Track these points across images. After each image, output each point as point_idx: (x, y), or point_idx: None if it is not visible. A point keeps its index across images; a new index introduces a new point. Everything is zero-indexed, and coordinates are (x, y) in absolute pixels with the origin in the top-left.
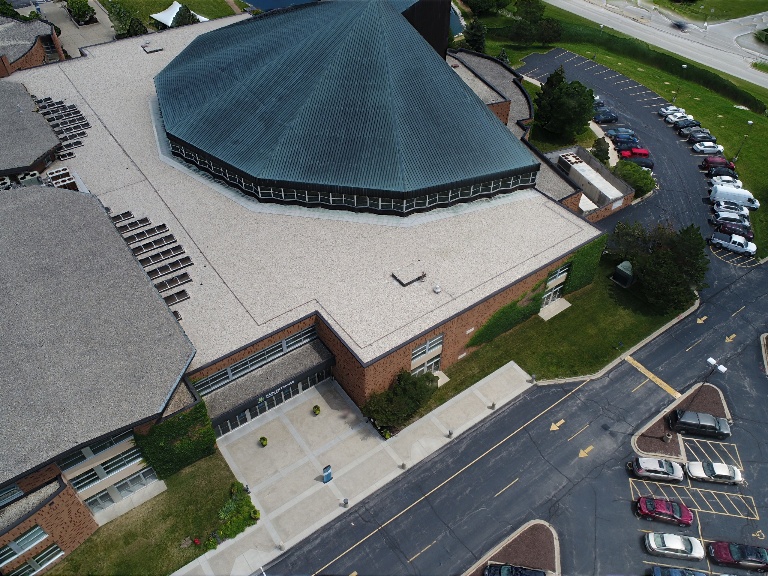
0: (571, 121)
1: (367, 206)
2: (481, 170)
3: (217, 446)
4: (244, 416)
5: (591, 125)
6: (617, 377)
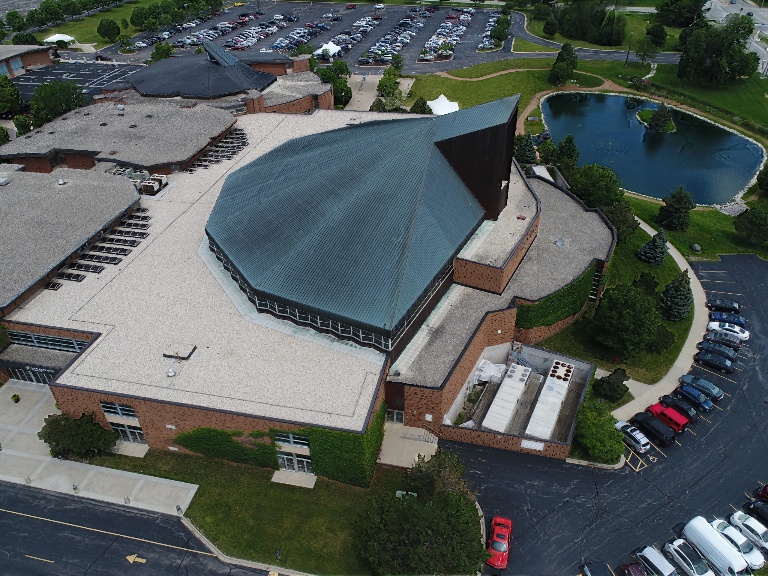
0: (610, 333)
1: (246, 288)
2: (330, 305)
3: (4, 382)
4: (31, 376)
5: (683, 359)
6: None
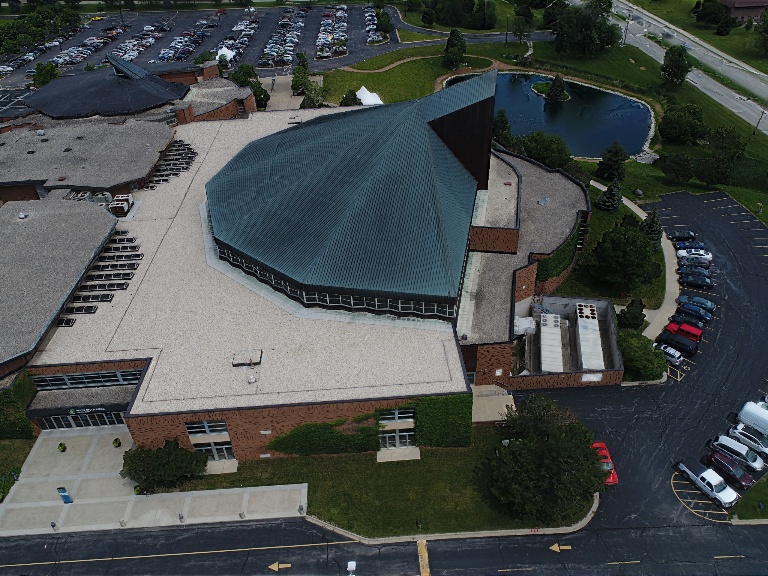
0: (616, 271)
1: (283, 287)
2: (388, 285)
3: (38, 435)
4: (69, 421)
5: (670, 284)
6: (388, 554)
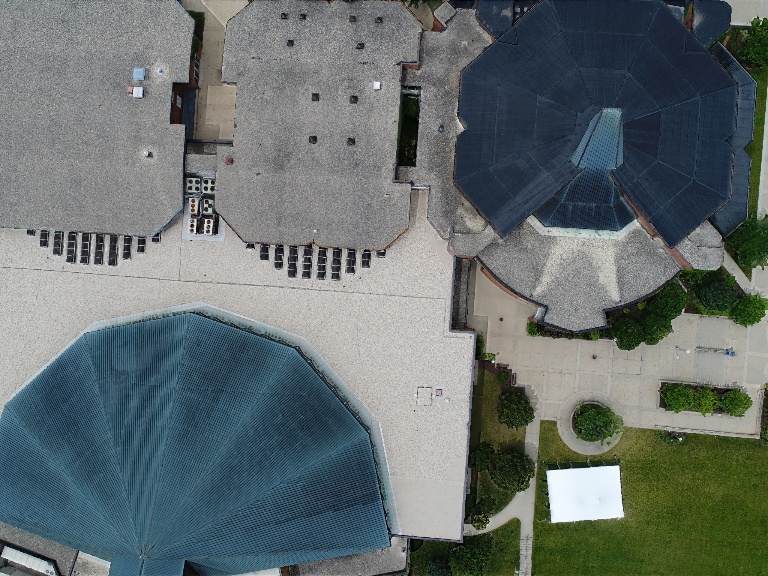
0: None
1: None
2: None
3: None
4: None
5: None
6: None
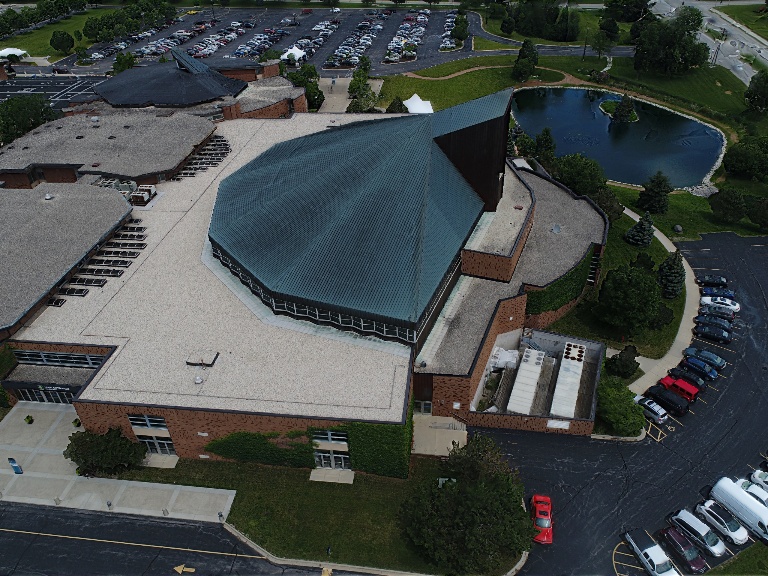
0: (616, 312)
1: (259, 291)
2: (351, 302)
3: (13, 404)
4: (42, 396)
5: (683, 333)
6: None
